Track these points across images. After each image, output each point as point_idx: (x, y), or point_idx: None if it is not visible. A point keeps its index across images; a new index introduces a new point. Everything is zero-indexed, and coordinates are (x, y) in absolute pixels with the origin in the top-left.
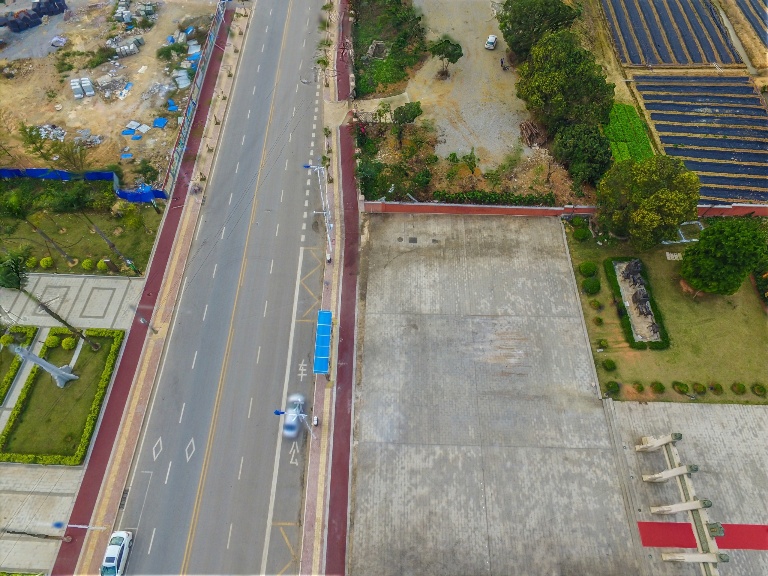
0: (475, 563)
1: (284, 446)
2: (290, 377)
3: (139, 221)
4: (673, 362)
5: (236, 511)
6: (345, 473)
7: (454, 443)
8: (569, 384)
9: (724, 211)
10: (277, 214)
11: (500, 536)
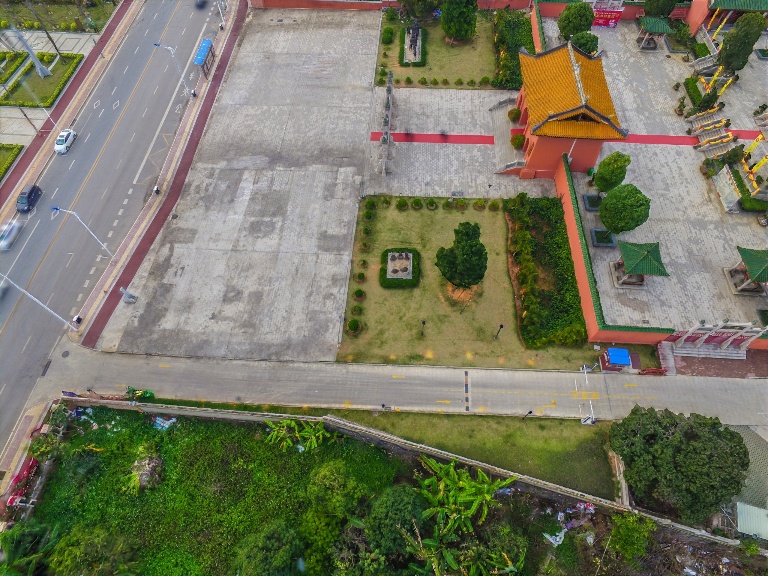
0: (272, 148)
1: (173, 105)
2: (184, 78)
3: (99, 0)
4: (424, 72)
5: (138, 128)
6: (207, 115)
7: (276, 104)
8: (356, 82)
9: (489, 4)
10: (193, 8)
11: (290, 139)
